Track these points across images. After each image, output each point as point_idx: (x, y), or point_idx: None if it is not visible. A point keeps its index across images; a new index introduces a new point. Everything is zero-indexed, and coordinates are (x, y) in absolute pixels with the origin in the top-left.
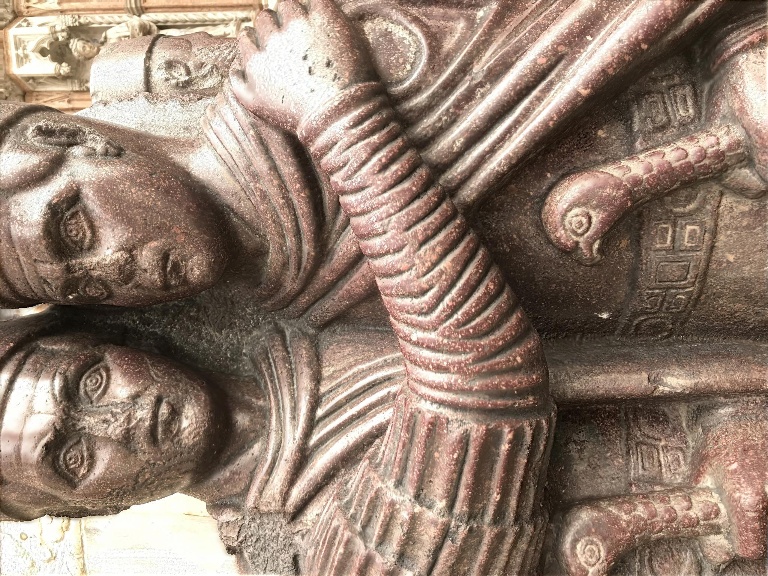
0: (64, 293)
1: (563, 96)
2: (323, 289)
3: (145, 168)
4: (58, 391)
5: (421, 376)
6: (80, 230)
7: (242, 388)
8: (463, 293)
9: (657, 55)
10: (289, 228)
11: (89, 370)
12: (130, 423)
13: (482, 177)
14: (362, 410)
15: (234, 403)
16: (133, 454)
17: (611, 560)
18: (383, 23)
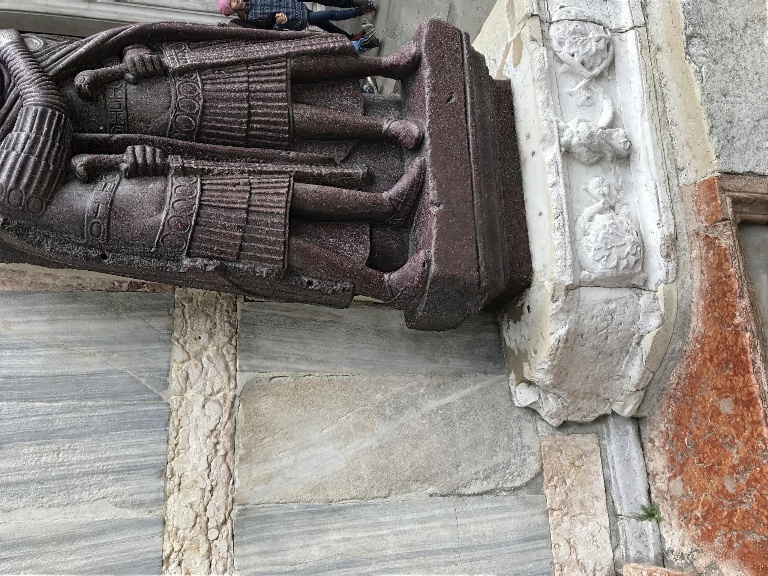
0: None
1: (78, 51)
2: (1, 120)
3: None
4: None
5: None
6: None
7: None
8: (41, 80)
9: (106, 48)
10: None
11: None
12: None
13: (55, 69)
14: None
15: None
16: None
17: (86, 162)
18: (31, 39)
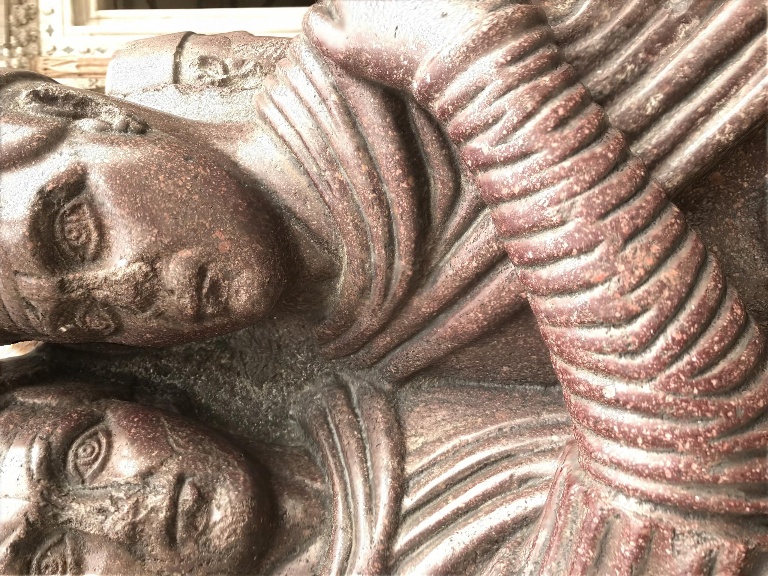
0: (54, 323)
1: None
2: (415, 326)
3: (179, 151)
4: (36, 464)
5: (620, 456)
6: (83, 231)
7: (291, 464)
8: (698, 320)
9: None
10: (379, 235)
11: (83, 434)
12: (137, 514)
13: (693, 151)
14: (472, 501)
15: (281, 485)
16: (139, 561)
17: None
18: None
